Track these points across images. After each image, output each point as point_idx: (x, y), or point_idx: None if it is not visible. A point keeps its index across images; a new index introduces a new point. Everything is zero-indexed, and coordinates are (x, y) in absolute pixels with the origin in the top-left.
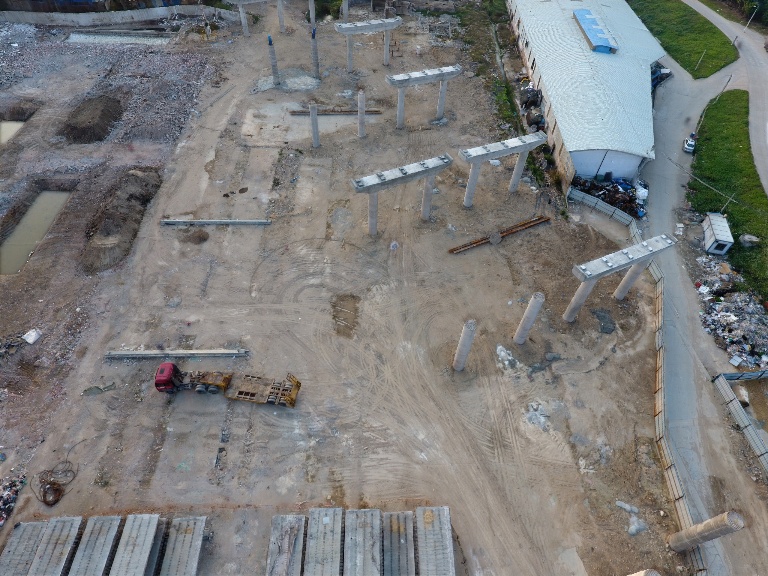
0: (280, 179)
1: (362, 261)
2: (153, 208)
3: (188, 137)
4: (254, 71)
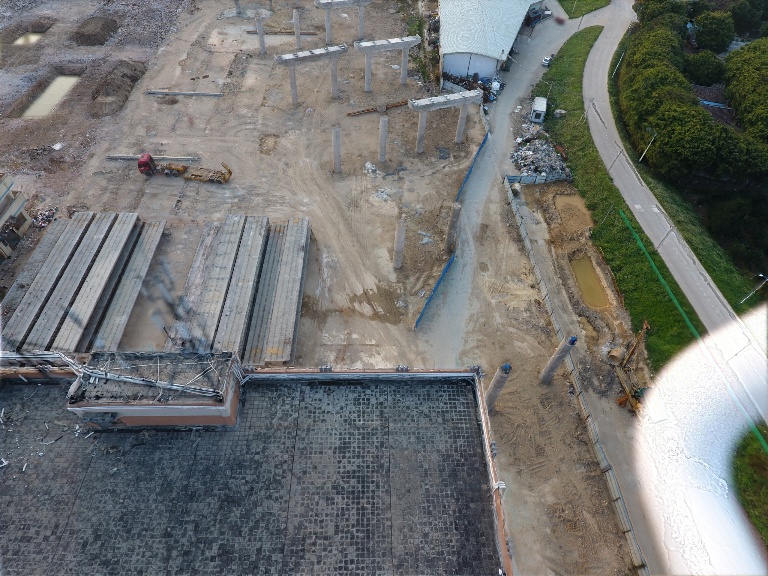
0: (233, 71)
1: (285, 118)
2: (140, 85)
3: (167, 45)
4: (222, 5)
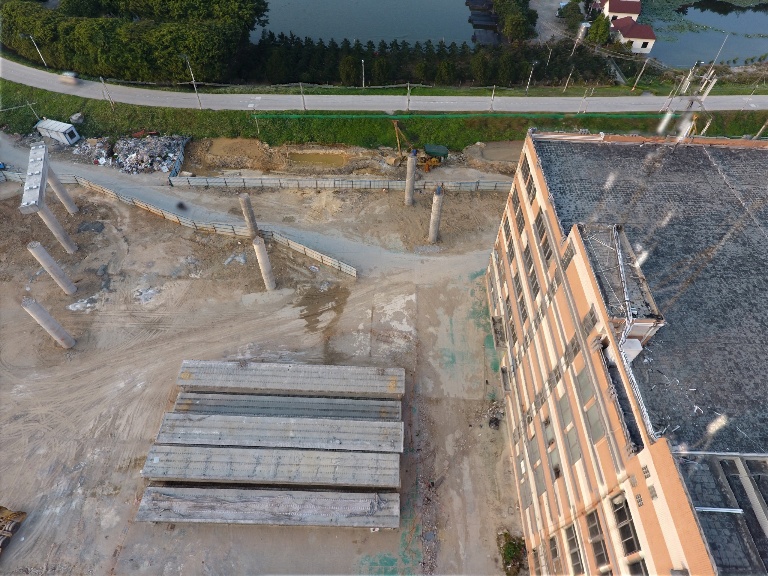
0: None
1: None
2: None
3: None
4: None
